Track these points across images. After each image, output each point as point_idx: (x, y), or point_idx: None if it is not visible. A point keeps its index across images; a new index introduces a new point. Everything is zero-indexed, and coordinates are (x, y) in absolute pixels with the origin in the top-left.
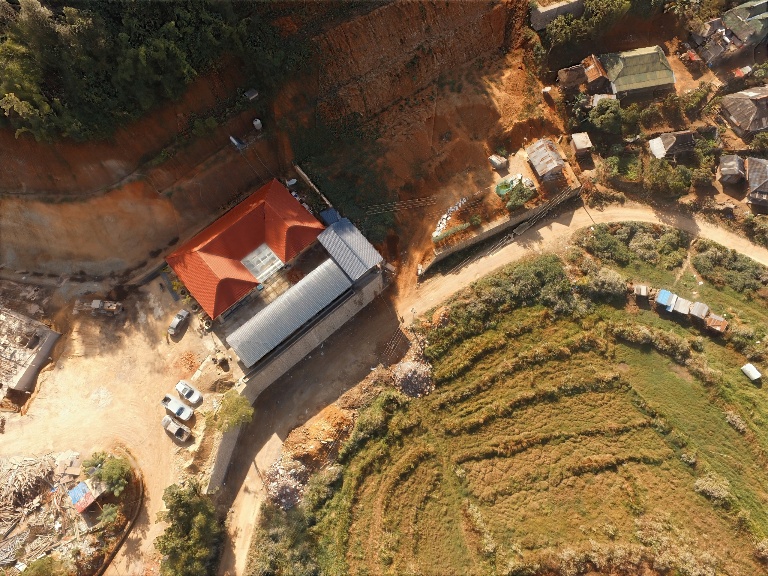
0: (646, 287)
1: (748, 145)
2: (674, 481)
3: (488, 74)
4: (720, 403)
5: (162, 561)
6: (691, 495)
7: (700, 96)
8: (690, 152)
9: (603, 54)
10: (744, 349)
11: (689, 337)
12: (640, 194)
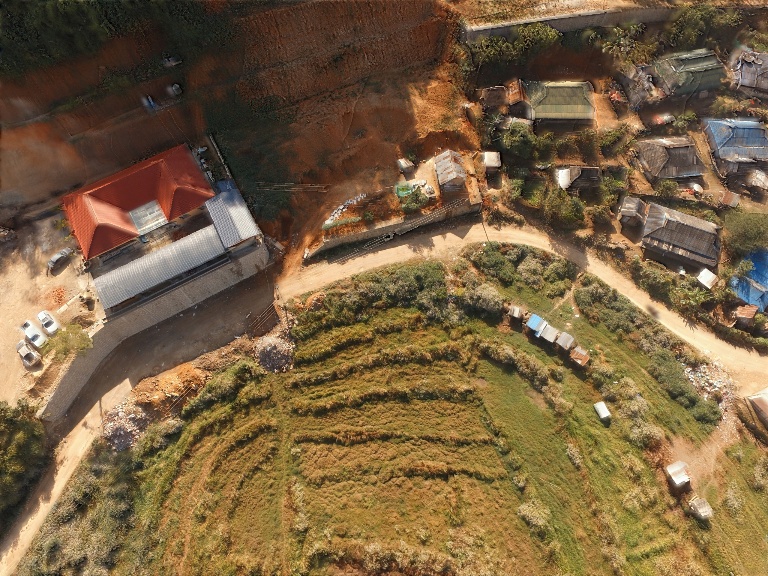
0: (520, 309)
1: (655, 191)
2: (499, 501)
3: (416, 81)
4: (564, 434)
5: None
6: (512, 517)
7: (618, 136)
8: (597, 188)
9: (532, 81)
10: (601, 387)
11: (551, 365)
12: (540, 221)
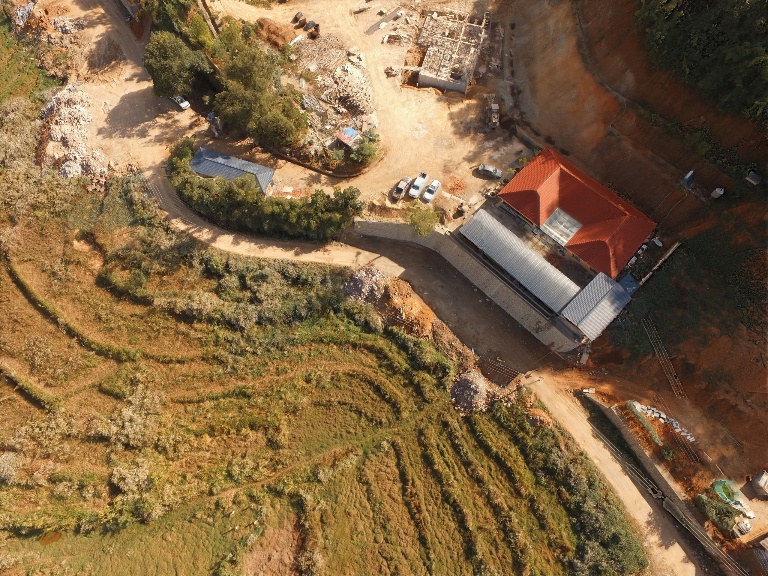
0: None
1: None
2: None
3: None
4: None
5: (308, 197)
6: None
7: None
8: None
9: None
10: None
11: None
12: None
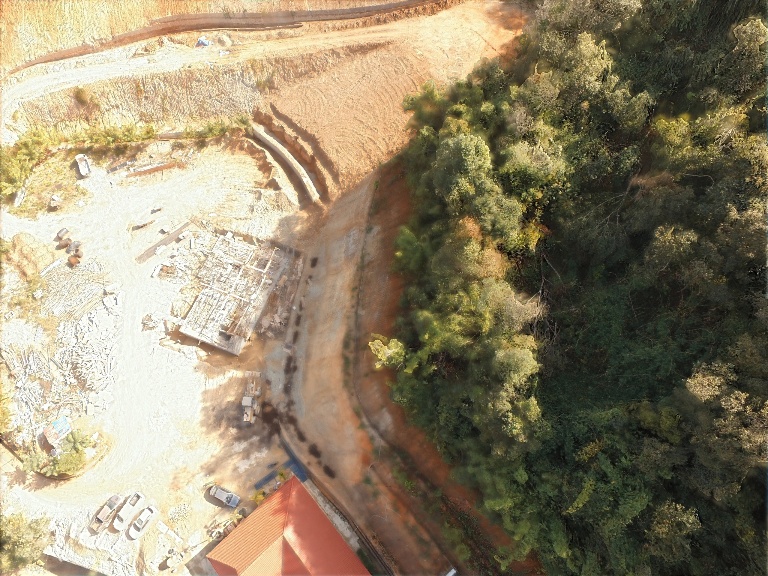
0: None
1: None
2: None
3: None
4: None
5: None
6: None
7: None
8: None
9: None
10: None
11: None
12: None
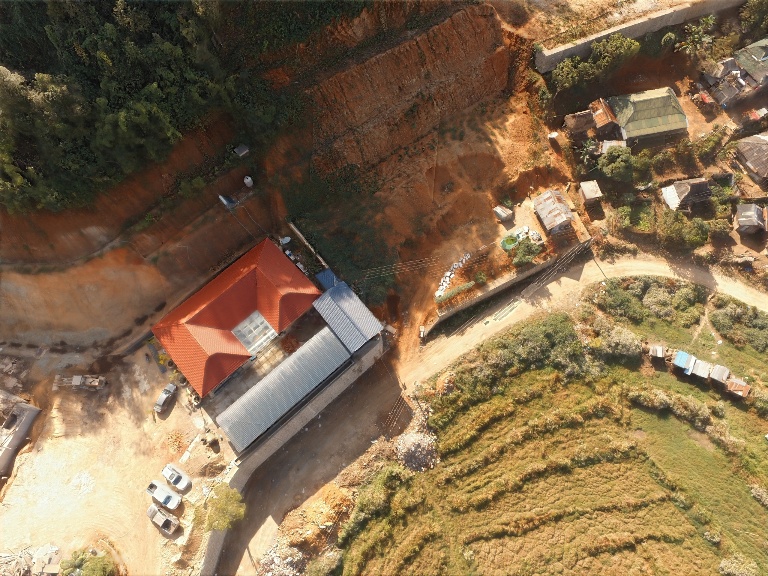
0: (662, 348)
1: (766, 192)
2: (697, 562)
3: (491, 120)
4: (744, 475)
5: None
6: None
7: (714, 141)
8: (705, 200)
9: (612, 97)
10: (767, 415)
11: (709, 402)
12: (653, 245)
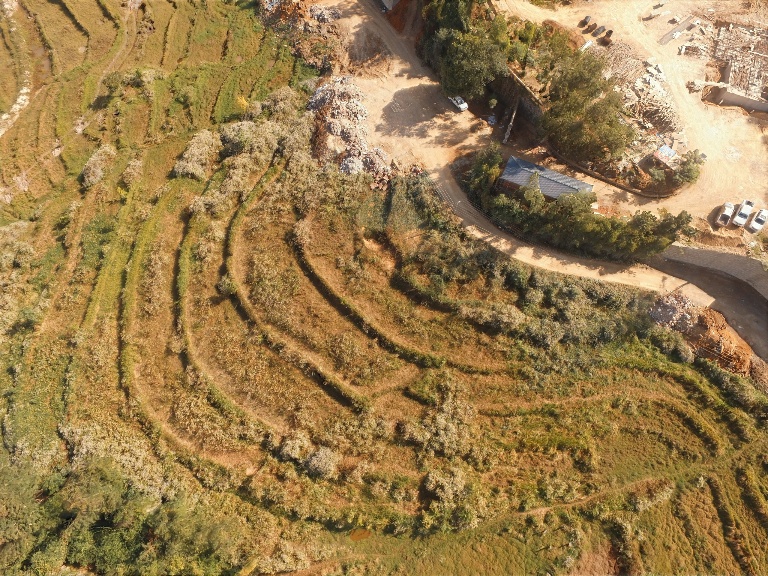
0: None
1: None
2: None
3: None
4: None
5: None
6: None
7: None
8: None
9: None
10: None
11: None
12: None
